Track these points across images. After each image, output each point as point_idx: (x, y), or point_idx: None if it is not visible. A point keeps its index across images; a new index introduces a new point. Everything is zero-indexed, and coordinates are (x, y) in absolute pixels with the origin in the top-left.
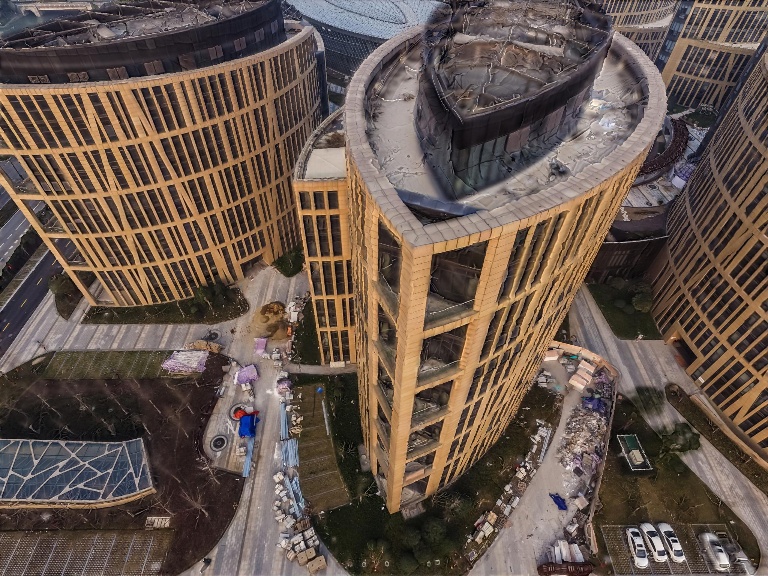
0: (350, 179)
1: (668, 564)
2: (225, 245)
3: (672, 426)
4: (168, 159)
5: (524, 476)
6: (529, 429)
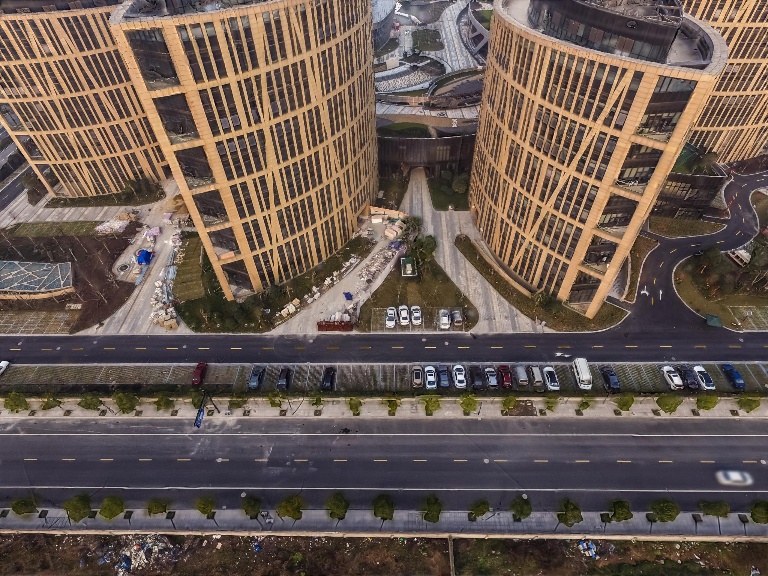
0: None
1: (410, 327)
2: (146, 148)
3: (450, 257)
4: (90, 72)
5: (329, 283)
6: (343, 258)
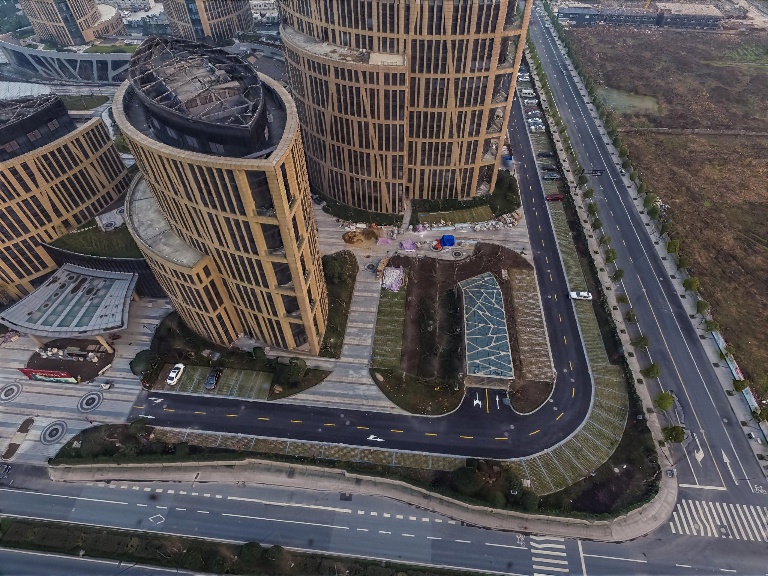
0: (477, 6)
1: None
2: None
3: None
4: None
5: None
6: None
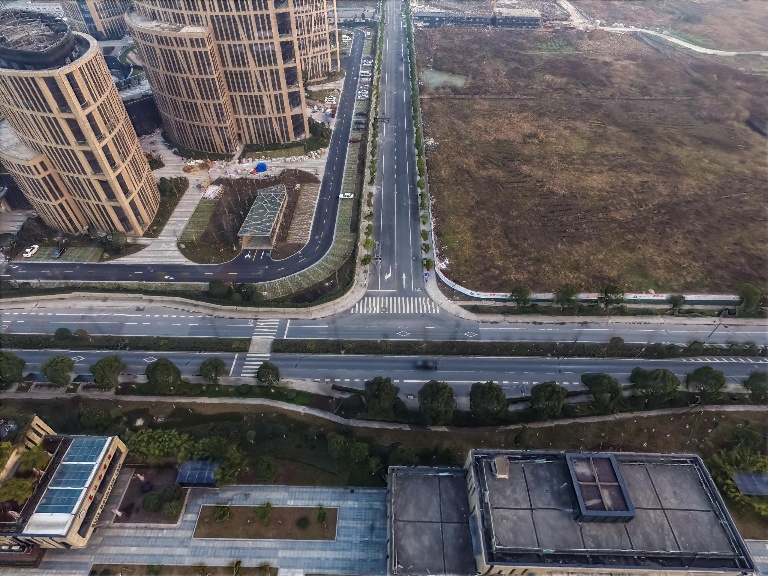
0: None
1: None
2: None
3: None
4: None
5: None
6: None
